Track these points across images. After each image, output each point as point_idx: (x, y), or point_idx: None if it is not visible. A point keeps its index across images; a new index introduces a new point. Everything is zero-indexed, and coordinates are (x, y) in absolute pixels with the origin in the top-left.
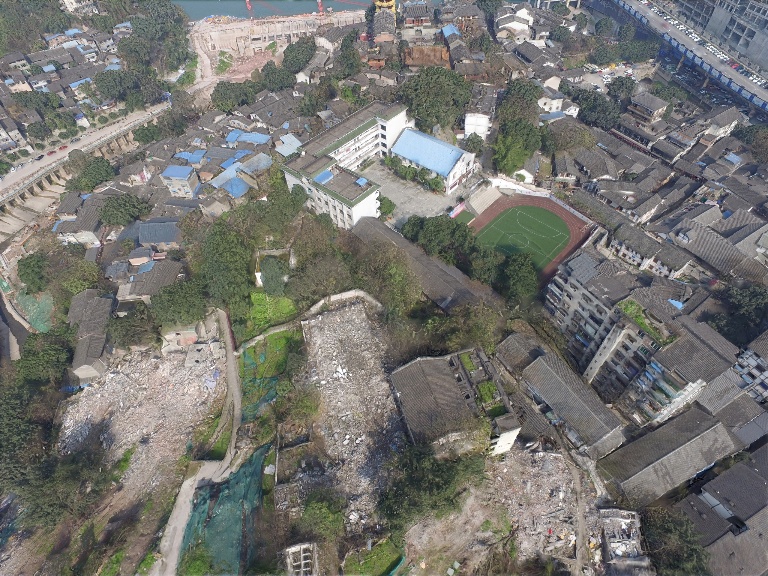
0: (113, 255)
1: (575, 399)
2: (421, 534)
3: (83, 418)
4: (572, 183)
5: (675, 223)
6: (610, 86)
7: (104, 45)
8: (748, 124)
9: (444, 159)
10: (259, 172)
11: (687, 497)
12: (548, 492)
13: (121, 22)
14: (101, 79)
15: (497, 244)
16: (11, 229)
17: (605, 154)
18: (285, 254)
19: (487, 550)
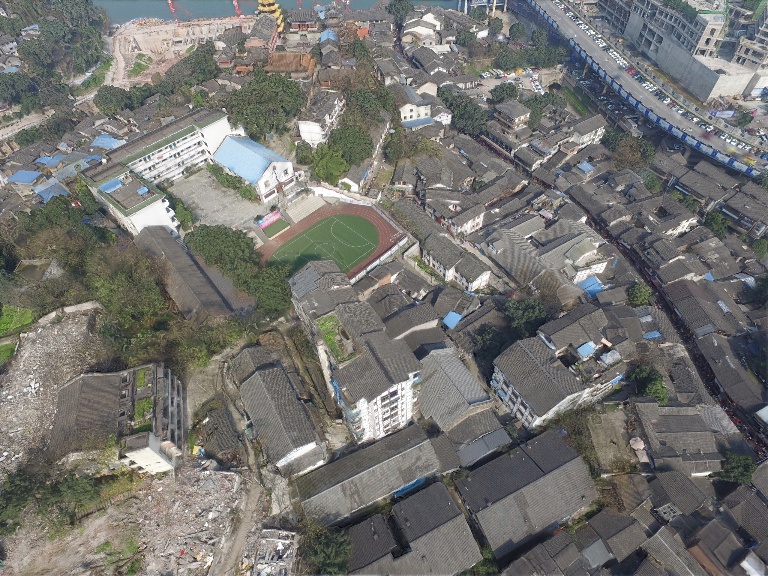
0: None
1: (274, 415)
2: (24, 556)
3: None
4: (408, 191)
5: None
6: (492, 92)
7: (7, 48)
8: (636, 131)
9: (255, 167)
10: (70, 179)
11: (372, 517)
12: (196, 512)
13: (31, 24)
14: None
15: (301, 253)
16: None
17: (461, 162)
18: (47, 264)
19: (85, 573)
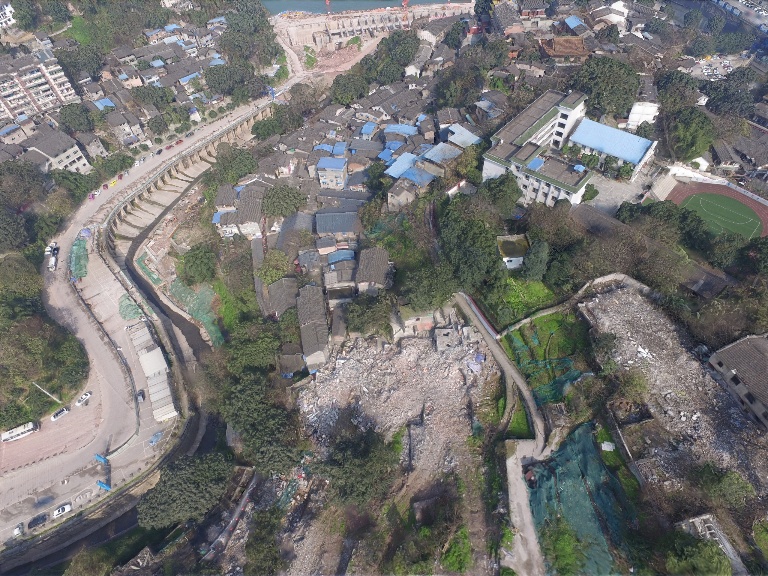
0: (284, 245)
1: None
2: None
3: (328, 403)
4: (736, 171)
5: None
6: (730, 76)
7: (204, 40)
8: None
9: (632, 147)
10: (448, 161)
11: None
12: None
13: (213, 17)
14: (212, 73)
15: None
16: (143, 223)
17: None
18: (521, 240)
19: None
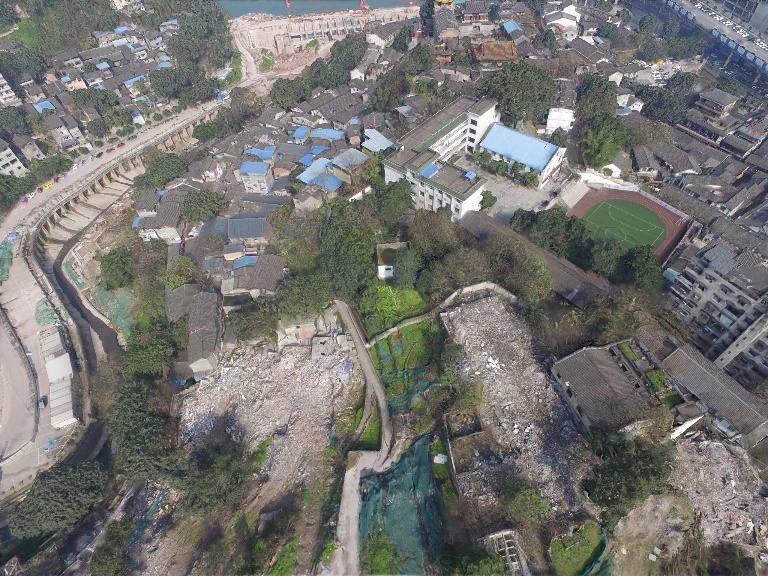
0: (198, 251)
1: (723, 389)
2: None
3: (206, 411)
4: (654, 177)
5: (766, 217)
6: (670, 82)
7: (154, 43)
8: None
9: (538, 153)
10: (353, 167)
11: None
12: (721, 480)
13: (167, 20)
14: (156, 76)
15: (594, 238)
16: (77, 226)
17: None
18: (404, 247)
19: (684, 536)
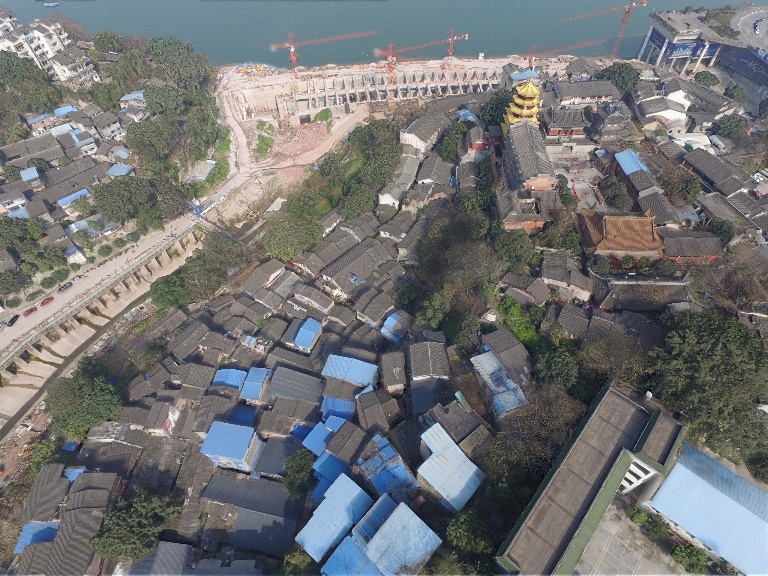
0: None
1: None
2: None
3: None
4: None
5: None
6: None
7: (107, 131)
8: None
9: None
10: (410, 575)
11: None
12: None
13: (130, 90)
14: (102, 196)
15: None
16: None
17: None
18: None
19: None
